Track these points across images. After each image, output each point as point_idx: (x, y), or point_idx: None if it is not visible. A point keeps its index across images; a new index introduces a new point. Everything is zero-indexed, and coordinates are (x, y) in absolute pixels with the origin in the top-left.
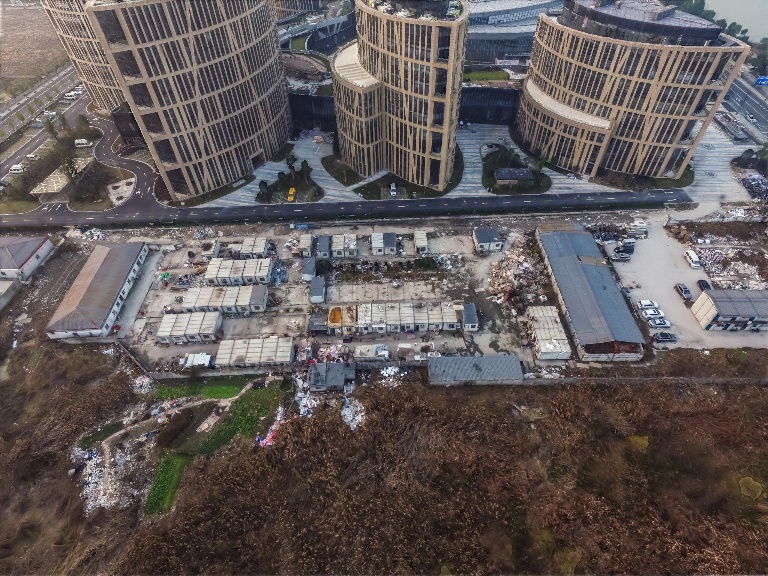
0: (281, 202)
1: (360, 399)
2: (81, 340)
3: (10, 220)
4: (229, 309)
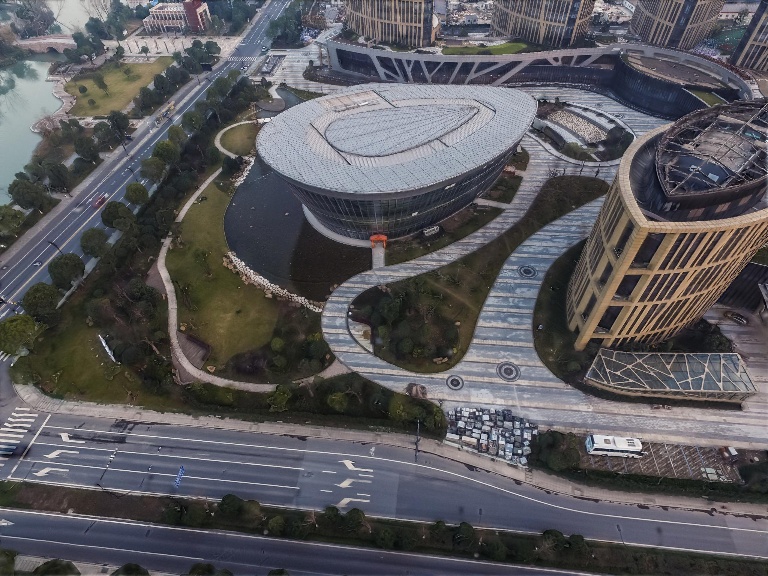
0: None
1: None
2: None
3: None
4: None
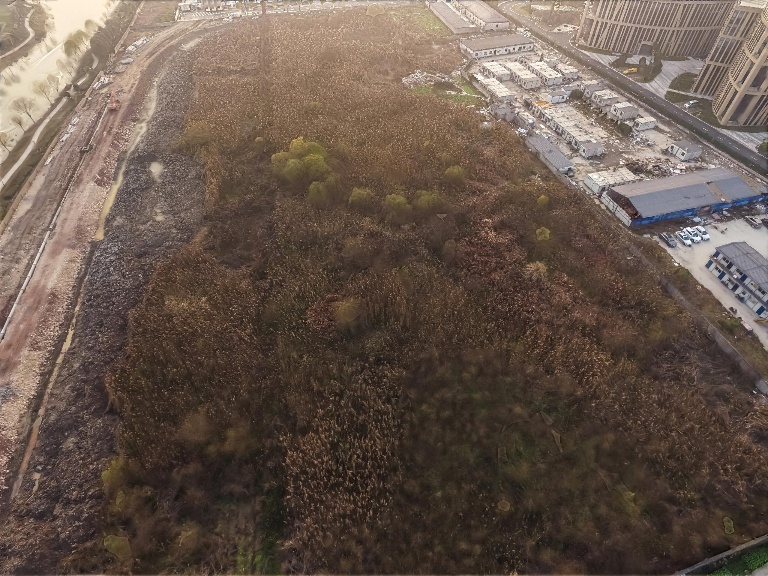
0: None
1: None
2: (465, 52)
3: (512, 14)
4: (516, 77)
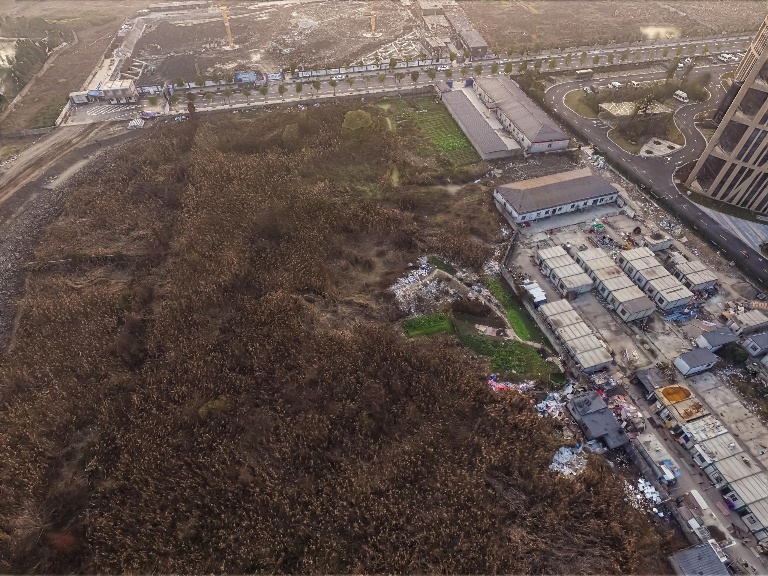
0: None
1: (590, 464)
2: (503, 210)
3: (568, 114)
4: (603, 289)
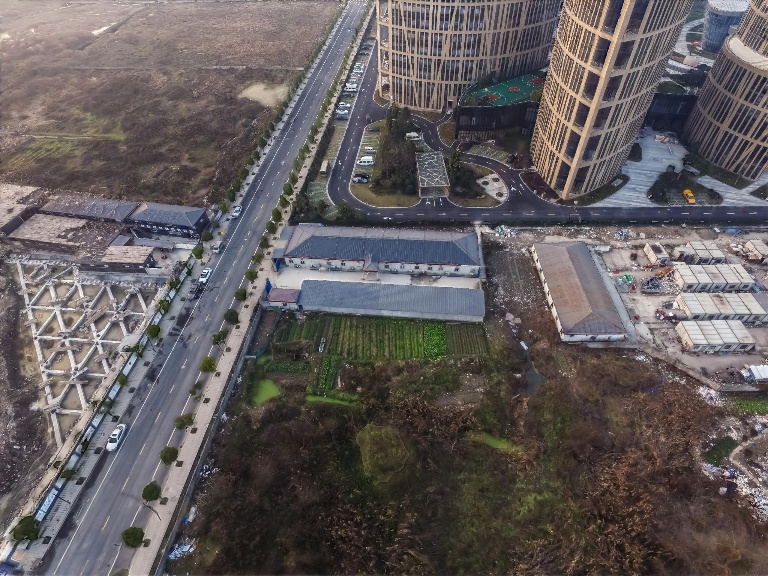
0: (683, 204)
1: None
2: (606, 344)
3: (402, 213)
4: (740, 318)
